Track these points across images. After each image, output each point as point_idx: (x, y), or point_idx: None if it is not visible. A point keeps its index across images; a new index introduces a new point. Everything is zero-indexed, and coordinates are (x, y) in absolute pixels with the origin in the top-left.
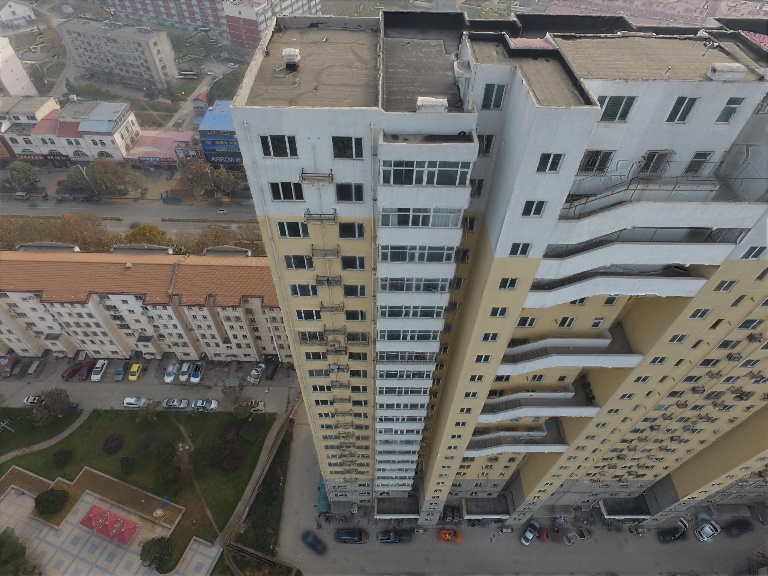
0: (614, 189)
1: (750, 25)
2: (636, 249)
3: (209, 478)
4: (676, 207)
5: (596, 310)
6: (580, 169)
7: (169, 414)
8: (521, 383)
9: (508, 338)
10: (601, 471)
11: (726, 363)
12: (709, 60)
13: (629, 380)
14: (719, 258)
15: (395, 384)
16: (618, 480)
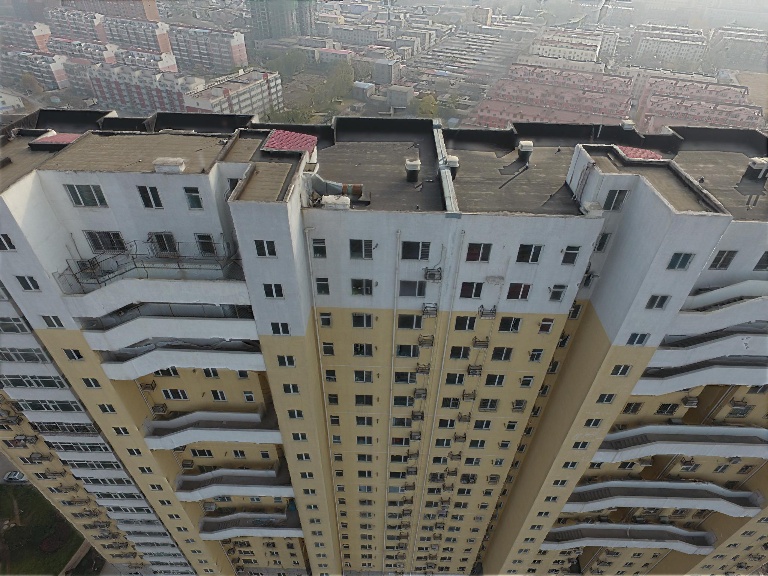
0: (124, 267)
1: (373, 123)
2: (162, 323)
3: (24, 560)
4: (160, 284)
5: (236, 383)
6: (105, 248)
7: (8, 488)
8: (227, 459)
9: (125, 410)
10: (397, 562)
11: (416, 442)
12: (194, 155)
13: (290, 457)
14: (252, 333)
15: (79, 457)
16: (425, 573)
